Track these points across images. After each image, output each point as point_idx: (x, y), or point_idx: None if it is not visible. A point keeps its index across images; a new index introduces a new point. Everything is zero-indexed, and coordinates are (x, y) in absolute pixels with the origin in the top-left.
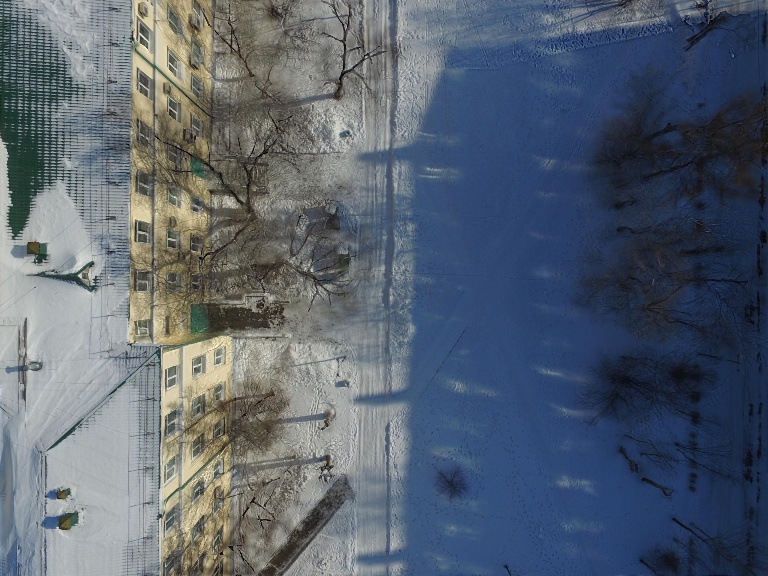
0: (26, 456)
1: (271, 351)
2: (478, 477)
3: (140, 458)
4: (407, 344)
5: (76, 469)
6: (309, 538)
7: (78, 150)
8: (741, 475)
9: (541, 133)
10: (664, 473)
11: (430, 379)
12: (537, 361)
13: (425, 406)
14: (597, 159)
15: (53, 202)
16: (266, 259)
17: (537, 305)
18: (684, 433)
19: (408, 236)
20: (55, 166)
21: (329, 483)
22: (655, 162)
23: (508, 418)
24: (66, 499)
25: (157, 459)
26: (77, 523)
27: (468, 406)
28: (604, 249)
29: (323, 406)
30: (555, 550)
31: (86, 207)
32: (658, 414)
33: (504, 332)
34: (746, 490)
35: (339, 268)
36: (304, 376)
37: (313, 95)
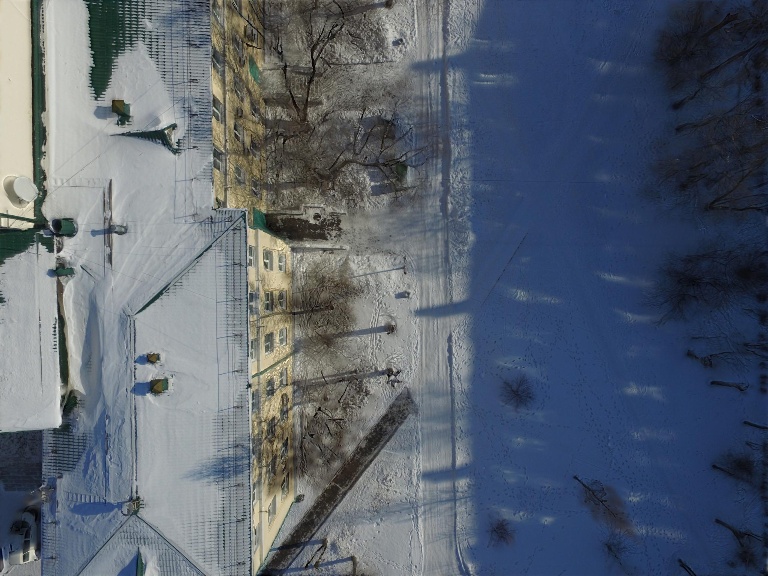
0: (113, 321)
1: (329, 264)
2: (544, 386)
3: (228, 325)
4: (467, 252)
5: (164, 334)
6: (372, 455)
7: (159, 11)
8: None
9: (595, 35)
10: (737, 369)
11: (491, 288)
12: (600, 265)
13: (487, 315)
14: (654, 57)
15: (135, 63)
16: (321, 171)
17: (597, 209)
18: (752, 333)
19: (465, 143)
20: (136, 27)
21: (392, 397)
22: (712, 60)
23: (572, 324)
24: (155, 365)
25: (245, 326)
26: (167, 390)
27: (531, 314)
28: (663, 149)
29: (383, 318)
30: (625, 459)
31: (168, 69)
32: (725, 315)
33: (565, 237)
34: None
35: (396, 178)
36: (363, 288)
37: (364, 4)
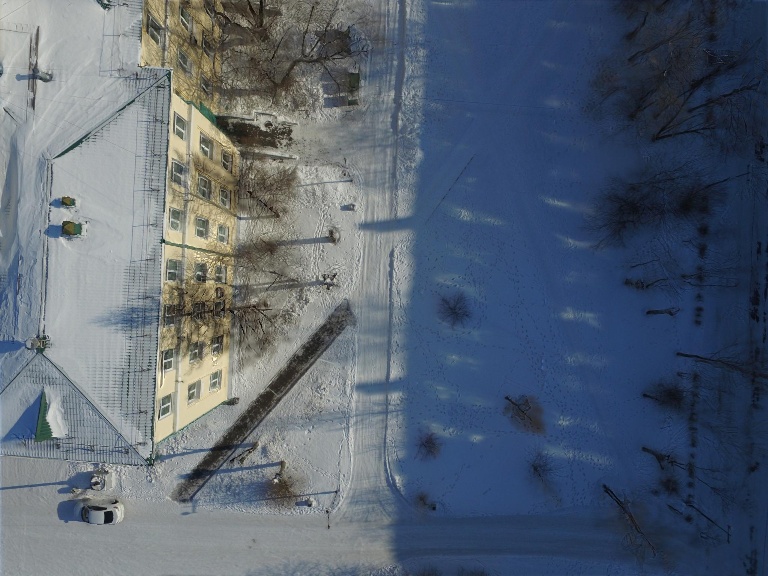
0: (32, 164)
1: (278, 172)
2: (481, 306)
3: (146, 179)
4: (414, 169)
5: (81, 181)
6: (309, 363)
7: None
8: (747, 313)
9: None
10: (670, 295)
11: (436, 206)
12: (544, 190)
13: (430, 233)
14: None
15: None
16: (276, 80)
17: (546, 134)
18: (691, 266)
19: (419, 61)
20: None
21: (331, 307)
22: None
23: (513, 247)
24: (70, 209)
25: (163, 182)
26: (80, 235)
27: (473, 234)
28: None
29: (328, 229)
30: (557, 383)
31: None
32: (665, 246)
33: (512, 160)
34: (752, 328)
35: None
36: (310, 197)
37: None
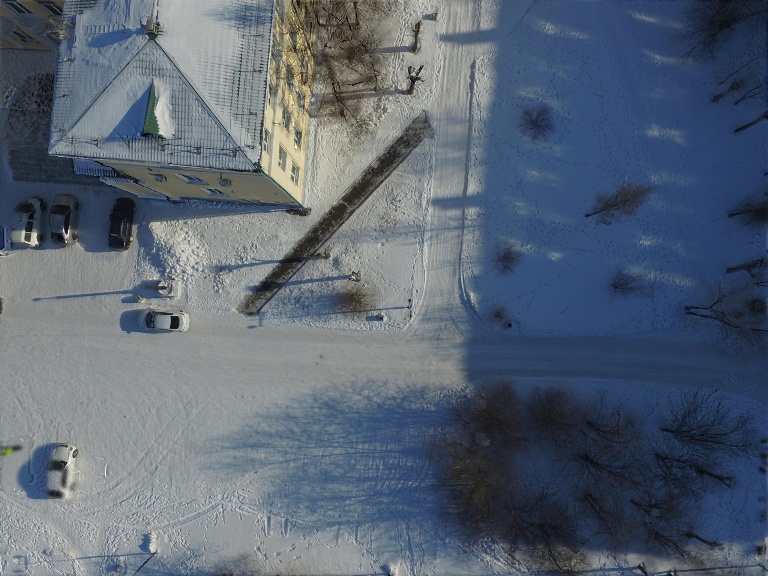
0: None
1: None
2: (564, 120)
3: None
4: None
5: None
6: (384, 176)
7: None
8: None
9: None
10: (765, 100)
11: (520, 18)
12: (632, 4)
13: (513, 46)
14: None
15: None
16: None
17: None
18: None
19: None
20: None
21: (409, 118)
22: None
23: (598, 61)
24: None
25: None
26: None
27: (558, 47)
28: None
29: (408, 39)
30: (639, 201)
31: None
32: None
33: None
34: None
35: None
36: (391, 5)
37: None
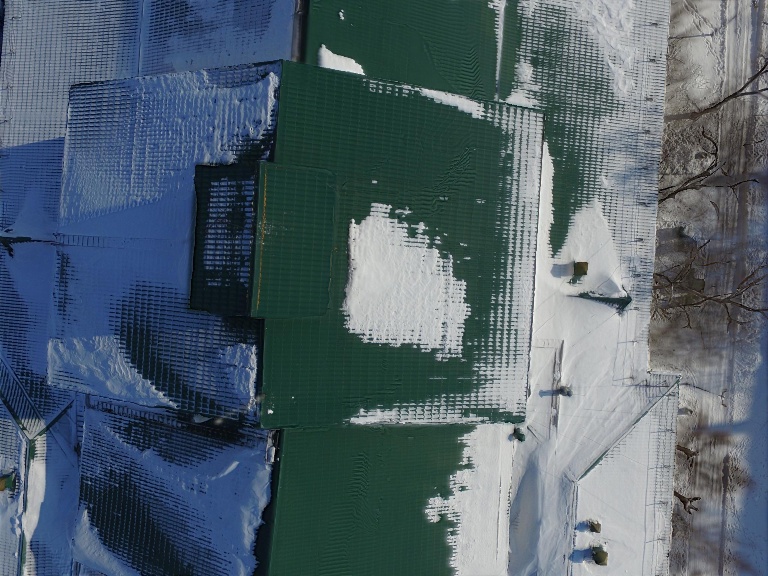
0: (554, 485)
1: None
2: None
3: (656, 492)
4: (752, 374)
5: (601, 501)
6: None
7: (615, 168)
8: None
9: None
10: None
11: None
12: None
13: (766, 439)
14: None
15: (590, 221)
16: None
17: None
18: None
19: (759, 263)
20: (593, 184)
21: None
22: None
23: None
24: (593, 532)
25: None
26: None
27: None
28: None
29: None
30: None
31: (617, 227)
32: None
33: None
34: None
35: (686, 292)
36: None
37: (670, 114)
